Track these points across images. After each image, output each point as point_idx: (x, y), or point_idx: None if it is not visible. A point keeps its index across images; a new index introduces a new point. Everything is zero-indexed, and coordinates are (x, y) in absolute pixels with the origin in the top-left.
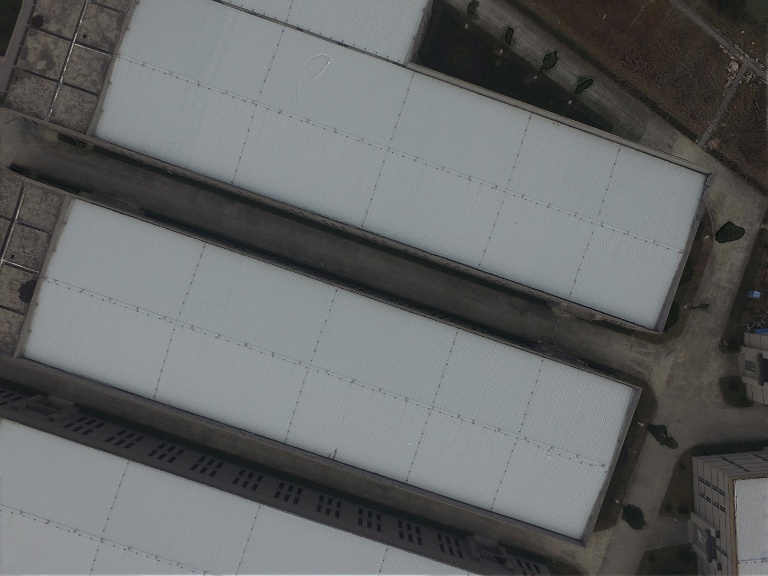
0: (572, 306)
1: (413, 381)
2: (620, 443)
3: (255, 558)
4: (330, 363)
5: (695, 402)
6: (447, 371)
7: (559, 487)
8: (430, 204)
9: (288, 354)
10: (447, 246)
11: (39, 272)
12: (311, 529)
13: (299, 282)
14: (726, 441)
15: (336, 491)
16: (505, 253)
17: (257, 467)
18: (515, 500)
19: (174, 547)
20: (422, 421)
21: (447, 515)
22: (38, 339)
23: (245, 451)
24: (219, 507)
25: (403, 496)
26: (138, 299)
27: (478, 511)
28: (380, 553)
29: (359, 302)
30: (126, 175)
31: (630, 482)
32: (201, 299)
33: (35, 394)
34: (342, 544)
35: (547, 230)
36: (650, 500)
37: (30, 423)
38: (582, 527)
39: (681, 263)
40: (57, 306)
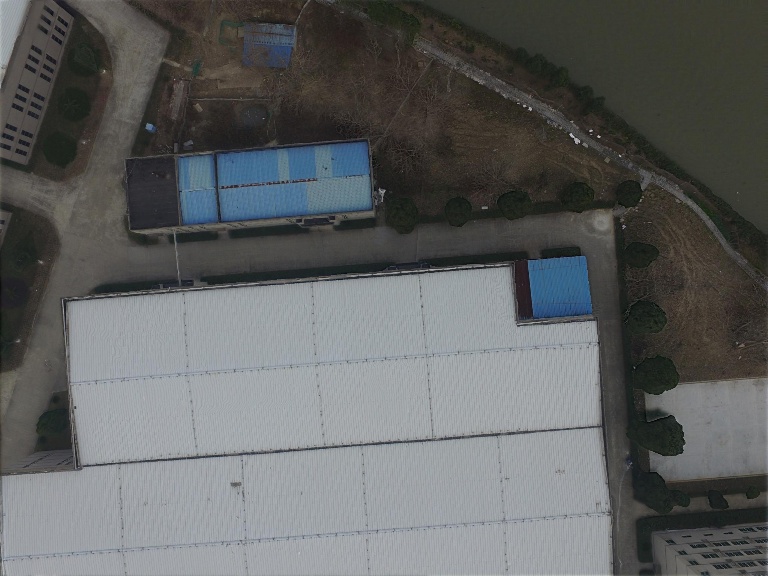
0: None
1: None
2: None
3: None
4: None
5: (99, 240)
6: None
7: None
8: None
9: None
10: None
11: None
12: None
13: None
14: (133, 280)
15: None
16: None
17: None
18: None
19: None
20: None
21: None
22: None
23: None
24: None
25: None
26: None
27: None
28: None
29: None
30: None
31: (35, 322)
32: None
33: None
34: None
35: None
36: (56, 341)
37: None
38: None
39: None
40: None
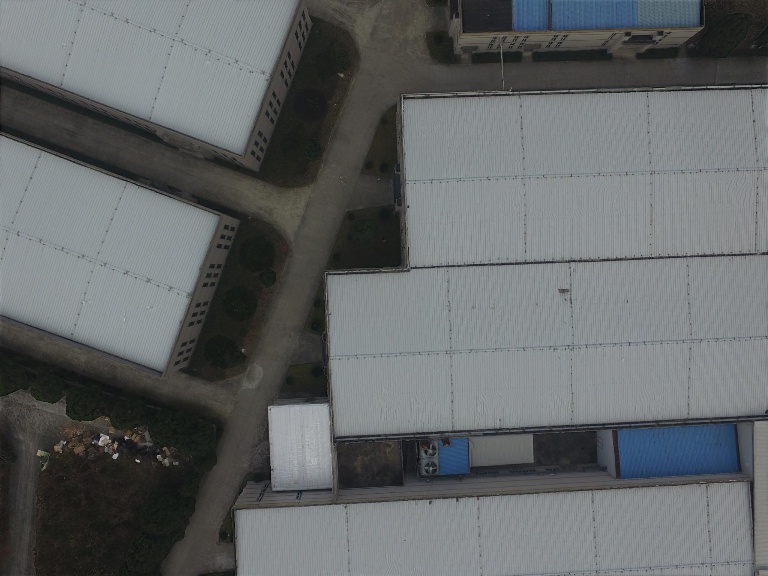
0: None
1: None
2: (281, 49)
3: None
4: None
5: (400, 57)
6: None
7: (219, 96)
8: None
9: None
10: None
11: None
12: None
13: None
14: None
15: (22, 133)
16: None
17: None
18: (174, 110)
19: None
20: (75, 19)
21: (139, 164)
22: None
23: None
24: None
25: (93, 142)
26: None
27: None
28: (32, 160)
29: None
30: None
31: (331, 137)
32: None
33: None
34: None
35: None
36: (352, 158)
37: None
38: (245, 141)
39: None
40: None
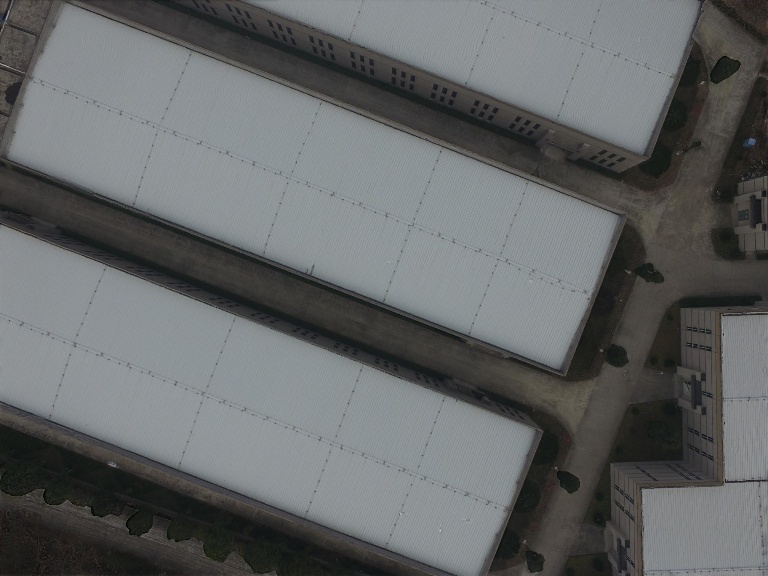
0: (560, 133)
1: (394, 197)
2: (604, 269)
3: (227, 371)
4: (311, 175)
5: (685, 253)
6: (429, 189)
7: (540, 313)
8: (418, 15)
9: (269, 164)
10: (434, 63)
11: (25, 71)
12: (285, 345)
13: (283, 94)
14: (716, 295)
15: (314, 326)
16: (492, 72)
17: (236, 298)
18: (494, 325)
19: (147, 355)
20: (402, 238)
21: (426, 357)
22: (22, 141)
23: (225, 282)
24: (194, 318)
25: (382, 335)
26: (122, 103)
27: (456, 333)
28: (354, 373)
29: (343, 116)
30: (119, 0)
31: (615, 332)
32: (185, 106)
33: (18, 213)
34: (316, 362)
35: (535, 45)
36: (635, 352)
37: (10, 224)
38: (562, 356)
39: (672, 88)
40: (42, 108)
